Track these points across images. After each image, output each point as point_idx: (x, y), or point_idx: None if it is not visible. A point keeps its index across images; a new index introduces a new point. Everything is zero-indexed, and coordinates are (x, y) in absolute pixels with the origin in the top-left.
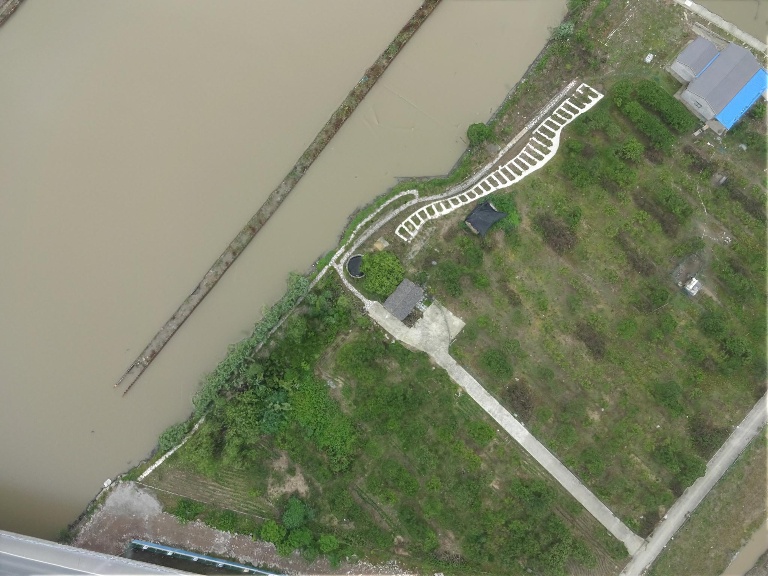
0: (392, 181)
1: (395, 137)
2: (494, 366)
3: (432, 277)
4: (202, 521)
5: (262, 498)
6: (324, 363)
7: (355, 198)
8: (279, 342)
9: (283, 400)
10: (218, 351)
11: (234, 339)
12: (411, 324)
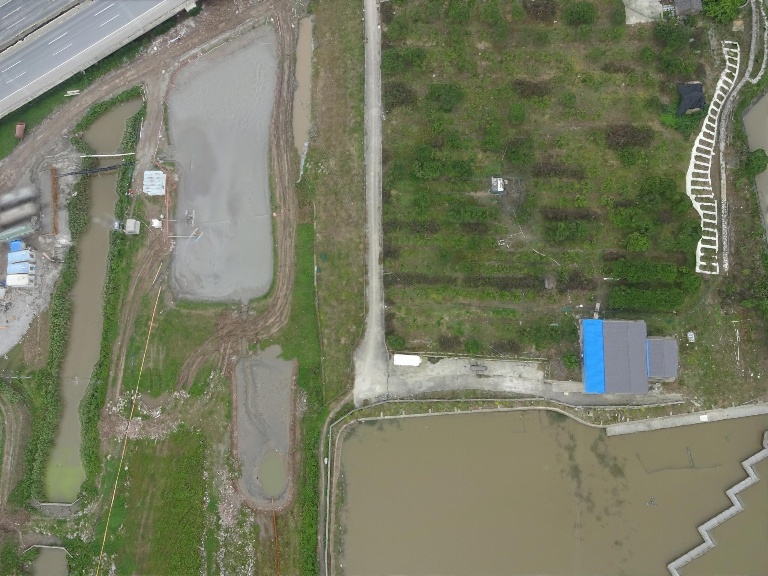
0: None
1: None
2: (584, 7)
3: None
4: None
5: None
6: None
7: None
8: None
9: None
10: None
11: None
12: None
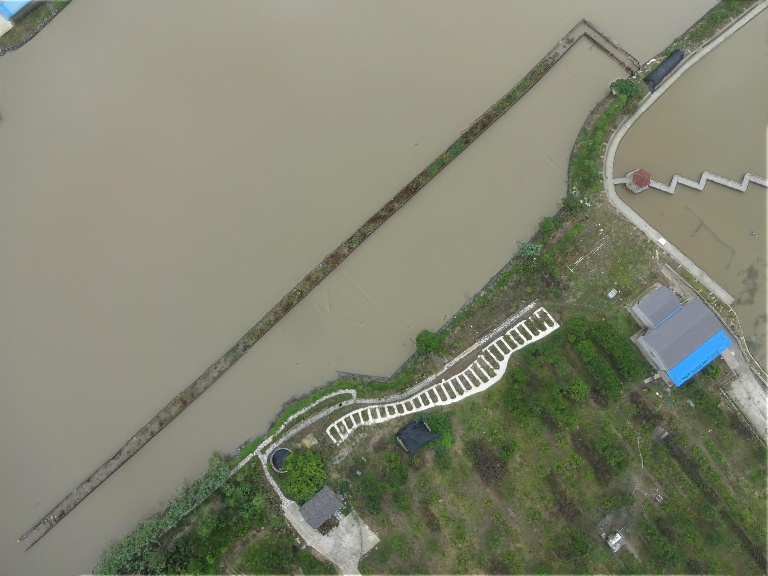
0: (333, 374)
1: (344, 329)
2: None
3: None
4: None
5: None
6: (230, 557)
7: (293, 386)
8: None
9: None
10: (128, 521)
11: (147, 510)
12: (325, 532)
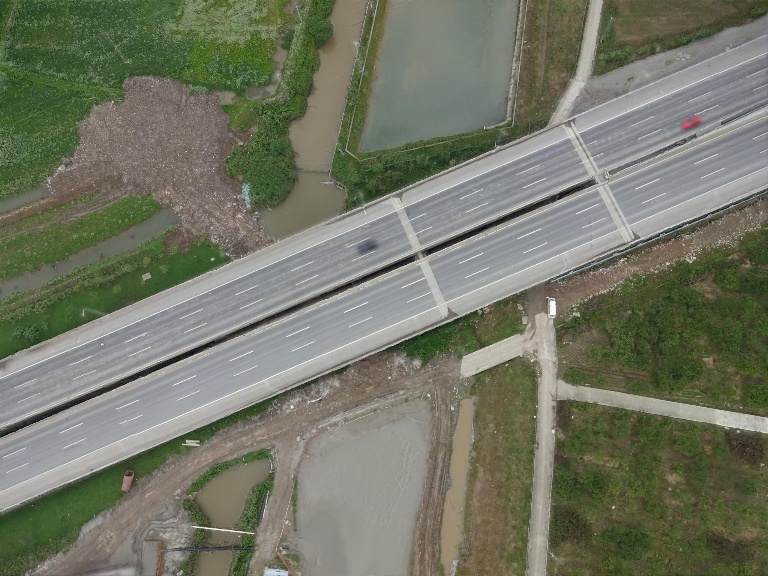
0: None
1: None
2: None
3: None
4: None
5: None
6: None
7: None
8: None
9: None
10: None
11: None
12: None
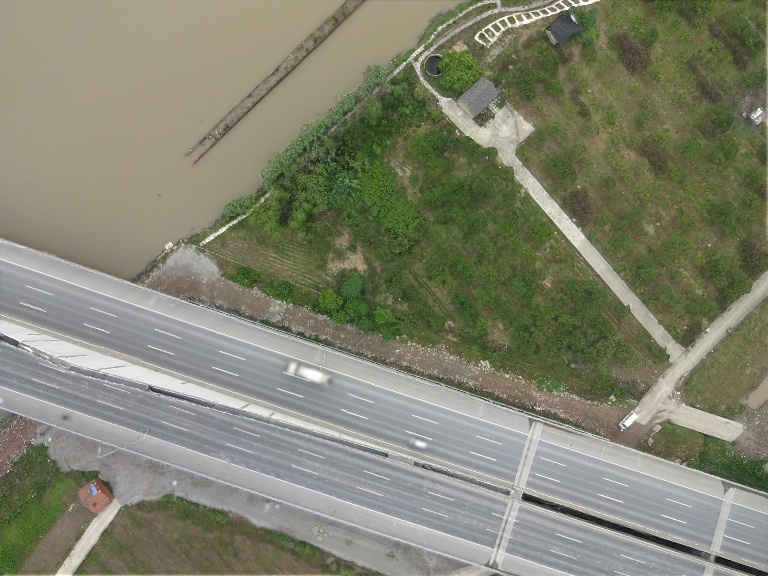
0: None
1: None
2: (560, 167)
3: (508, 80)
4: (259, 289)
5: (321, 271)
6: (394, 151)
7: (438, 3)
8: (352, 127)
9: (352, 178)
10: (289, 134)
11: None
12: (482, 123)
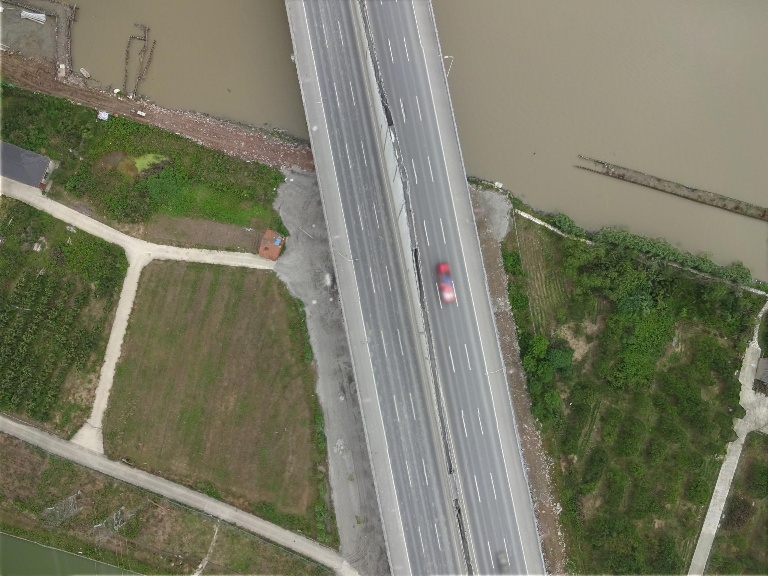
0: None
1: None
2: (764, 479)
3: None
4: (508, 280)
5: (555, 323)
6: (689, 327)
7: None
8: (688, 280)
9: None
10: (646, 230)
11: None
12: (758, 389)
